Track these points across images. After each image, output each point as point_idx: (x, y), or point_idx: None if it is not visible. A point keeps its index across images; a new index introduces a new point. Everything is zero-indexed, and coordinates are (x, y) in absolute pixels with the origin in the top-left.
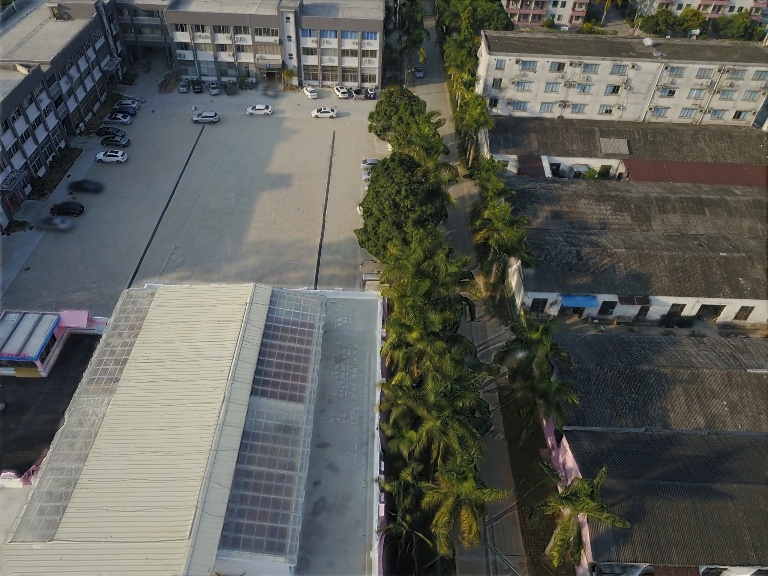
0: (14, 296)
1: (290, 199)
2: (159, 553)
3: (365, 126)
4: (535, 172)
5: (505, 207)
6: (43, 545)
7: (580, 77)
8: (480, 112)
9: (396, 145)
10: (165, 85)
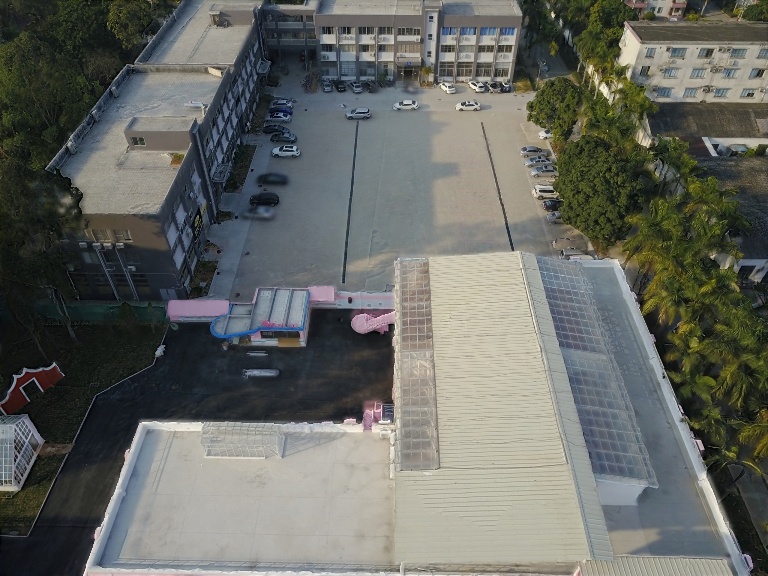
0: (245, 277)
1: (464, 185)
2: (545, 476)
3: (509, 117)
4: (701, 152)
5: (712, 180)
6: (434, 472)
7: (727, 62)
8: (644, 97)
9: (559, 132)
10: (309, 85)
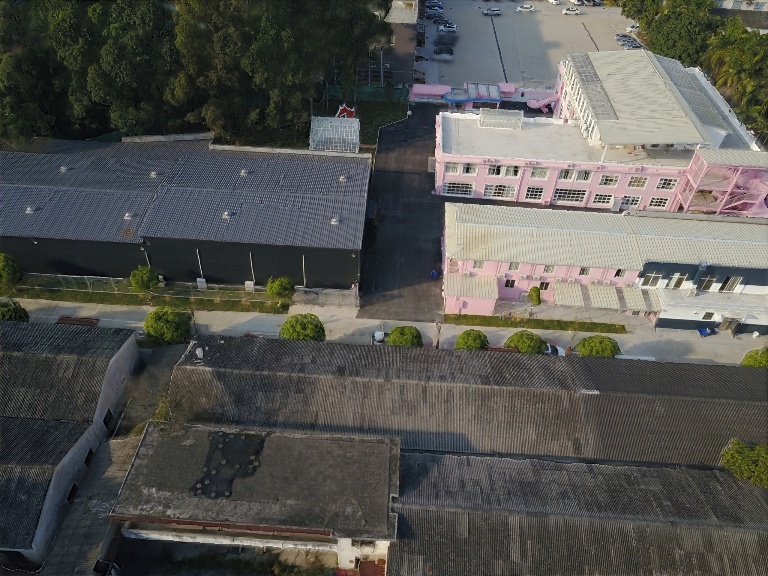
0: None
1: None
2: (675, 120)
3: (602, 20)
4: None
5: None
6: (616, 120)
7: None
8: None
9: (645, 21)
10: None
